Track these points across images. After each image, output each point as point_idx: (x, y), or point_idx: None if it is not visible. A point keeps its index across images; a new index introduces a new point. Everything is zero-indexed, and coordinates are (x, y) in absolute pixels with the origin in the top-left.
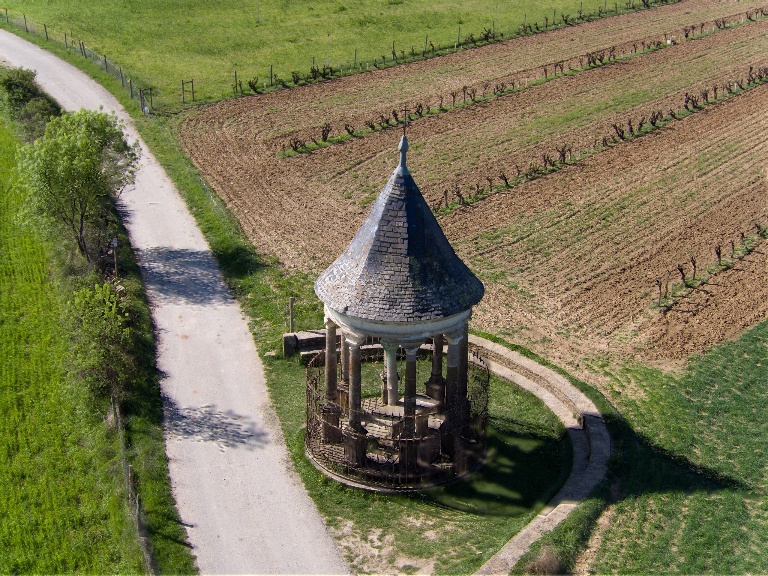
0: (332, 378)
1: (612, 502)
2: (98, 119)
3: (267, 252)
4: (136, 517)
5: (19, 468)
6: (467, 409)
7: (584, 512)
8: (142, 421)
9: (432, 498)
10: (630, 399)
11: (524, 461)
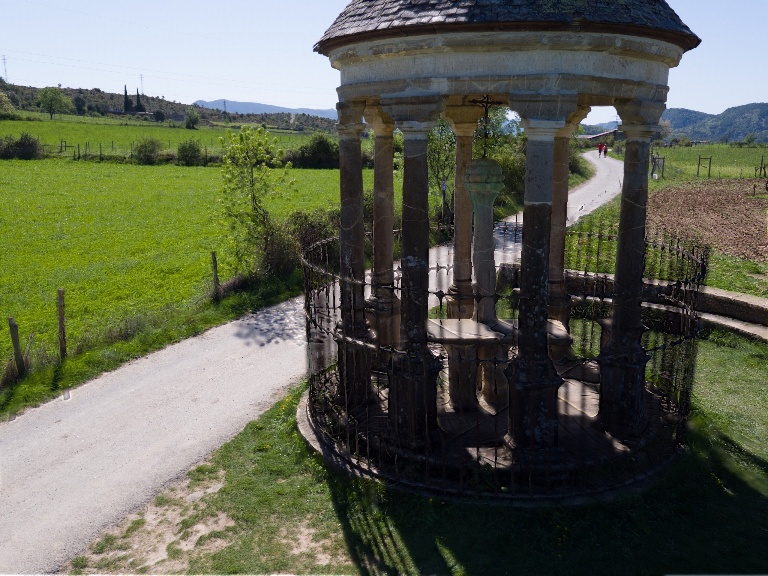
0: (379, 241)
1: None
2: None
3: None
4: (13, 354)
5: (99, 306)
6: (627, 367)
7: None
8: (243, 298)
9: (398, 513)
10: None
11: (730, 542)
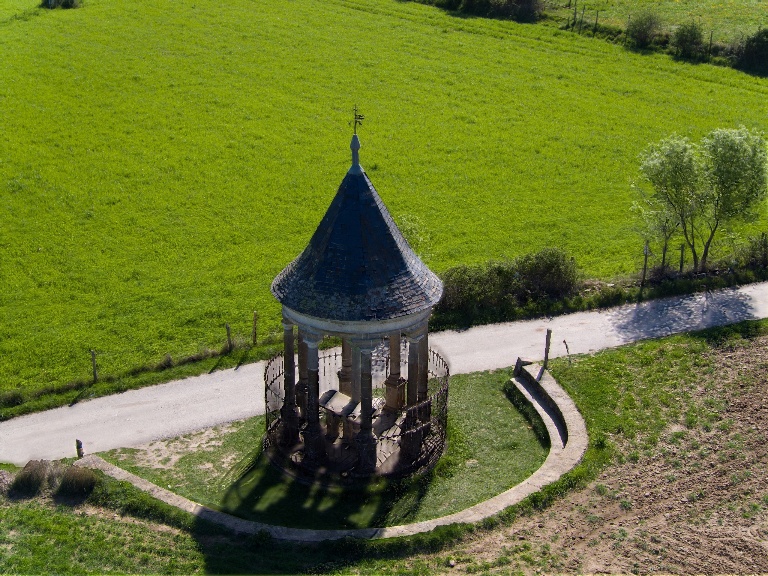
0: None
1: (195, 535)
2: (727, 139)
3: (760, 340)
4: None
5: None
6: None
7: (169, 509)
8: None
9: None
10: (434, 572)
11: (325, 514)
